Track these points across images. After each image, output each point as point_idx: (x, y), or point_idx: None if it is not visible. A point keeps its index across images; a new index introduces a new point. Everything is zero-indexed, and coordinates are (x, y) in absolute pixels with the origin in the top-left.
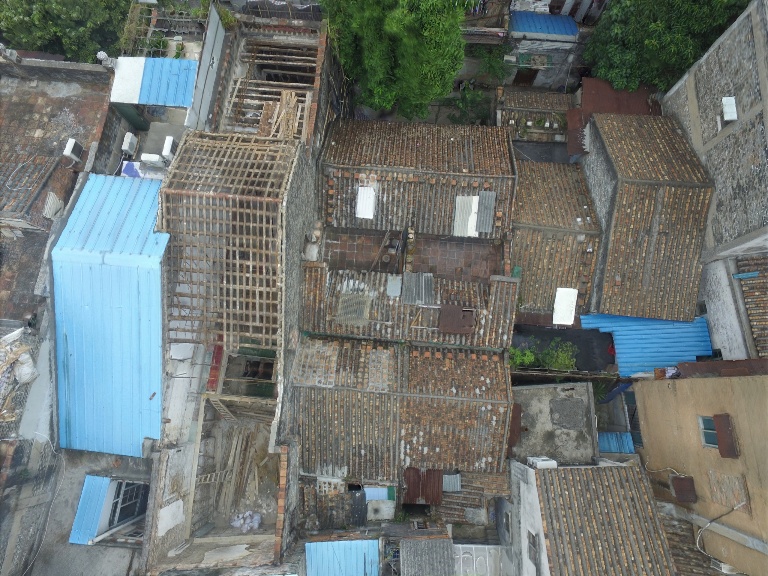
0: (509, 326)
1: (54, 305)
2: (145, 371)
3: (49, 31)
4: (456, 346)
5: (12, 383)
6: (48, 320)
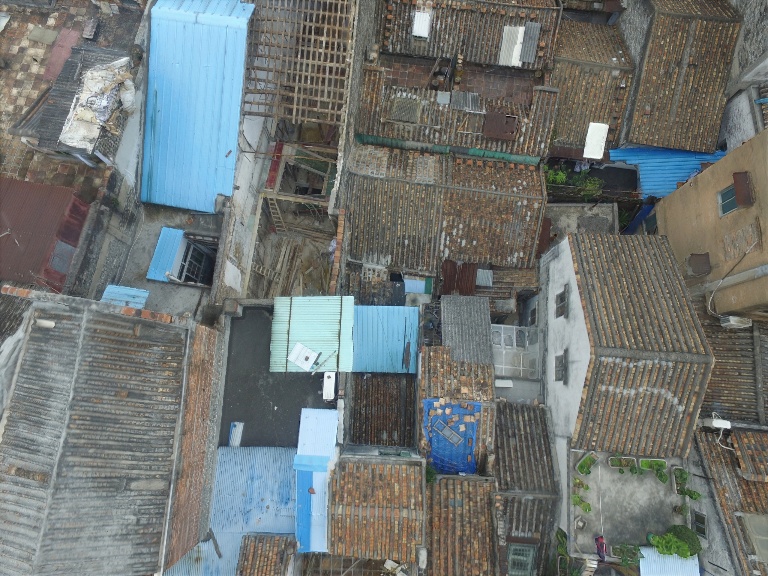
0: (547, 135)
1: (148, 61)
2: (224, 129)
3: None
4: (496, 159)
5: (118, 102)
6: (143, 74)
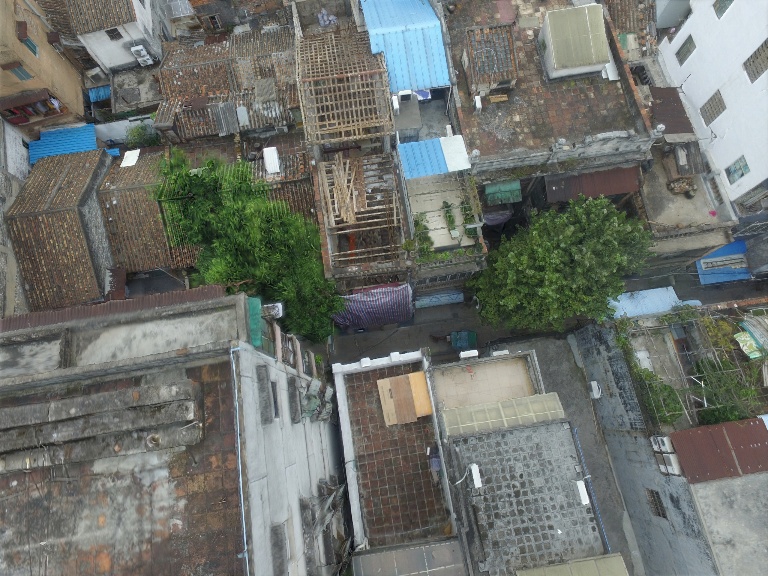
0: None
1: None
2: None
3: (571, 215)
4: None
5: None
6: (434, 3)
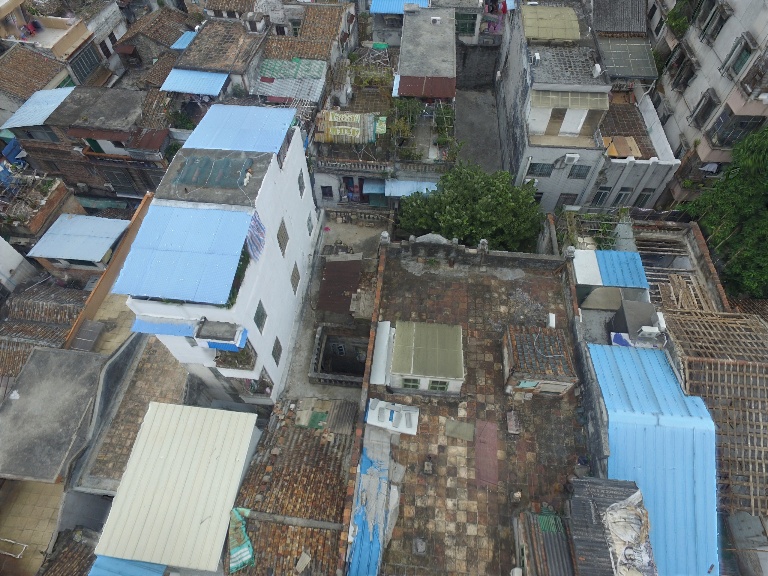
0: None
1: (607, 467)
2: (701, 539)
3: (465, 229)
4: None
5: None
6: None
